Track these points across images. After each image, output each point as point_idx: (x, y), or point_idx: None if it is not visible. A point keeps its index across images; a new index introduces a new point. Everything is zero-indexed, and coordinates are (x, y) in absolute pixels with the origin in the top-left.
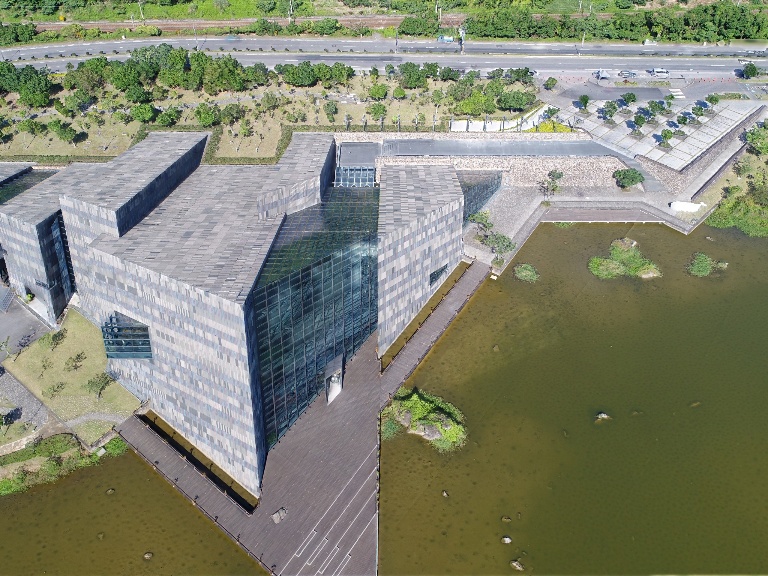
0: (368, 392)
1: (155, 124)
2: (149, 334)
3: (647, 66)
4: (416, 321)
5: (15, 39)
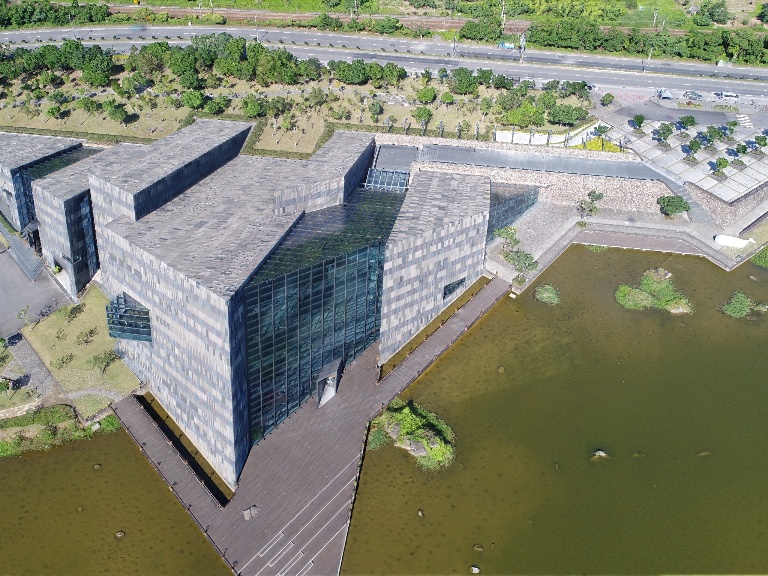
0: (361, 399)
1: (204, 111)
2: (150, 318)
3: (716, 88)
4: (424, 332)
5: (89, 19)
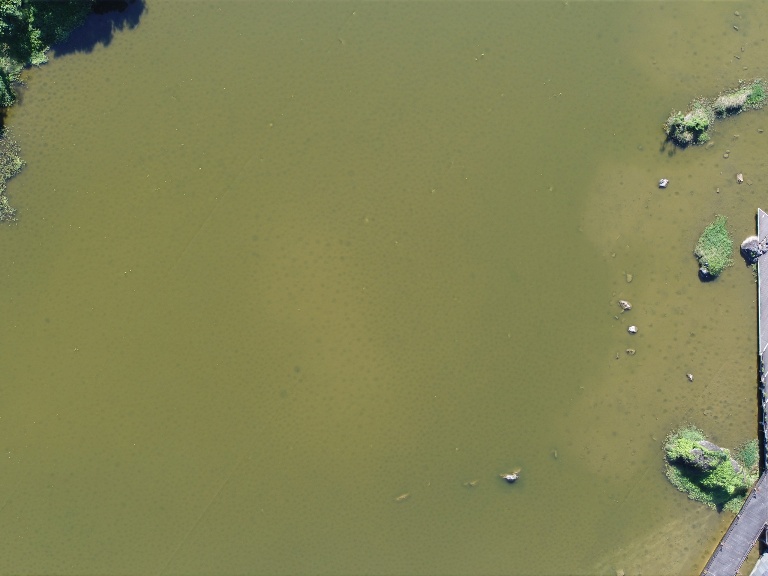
0: None
1: None
2: None
3: None
4: None
5: None
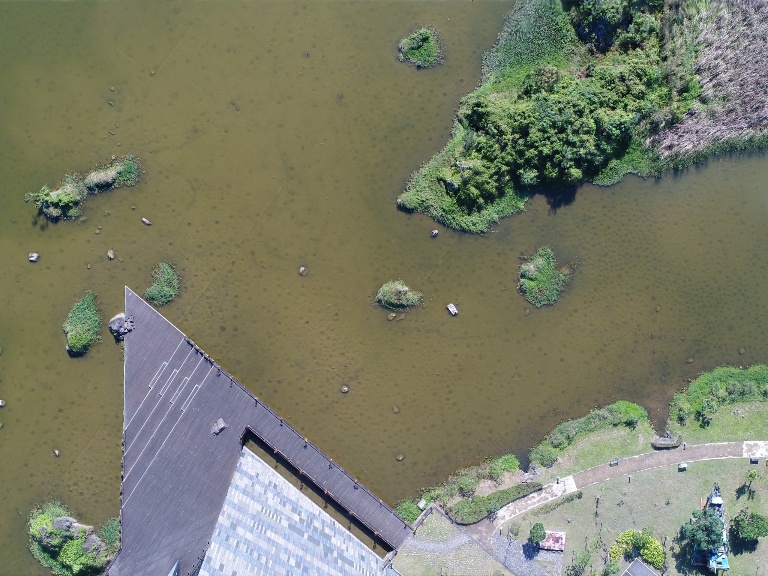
0: None
1: None
2: None
3: None
4: None
5: None
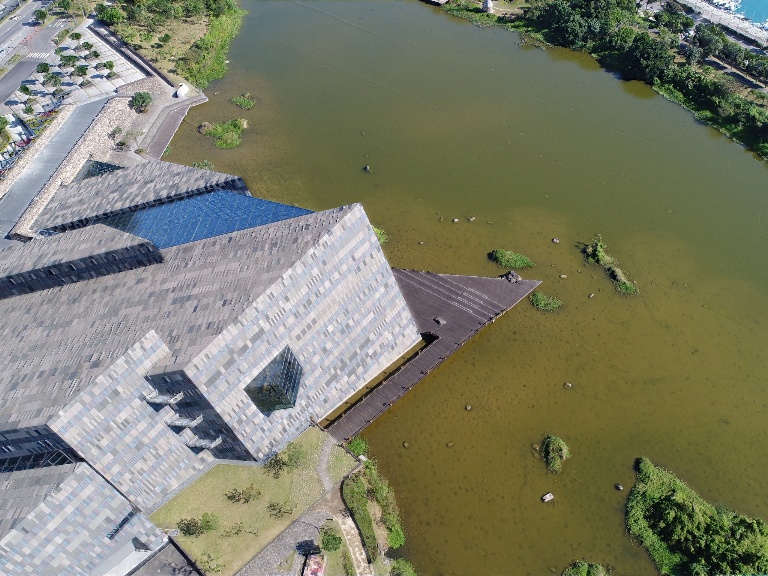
0: None
1: None
2: None
3: None
4: None
5: None
